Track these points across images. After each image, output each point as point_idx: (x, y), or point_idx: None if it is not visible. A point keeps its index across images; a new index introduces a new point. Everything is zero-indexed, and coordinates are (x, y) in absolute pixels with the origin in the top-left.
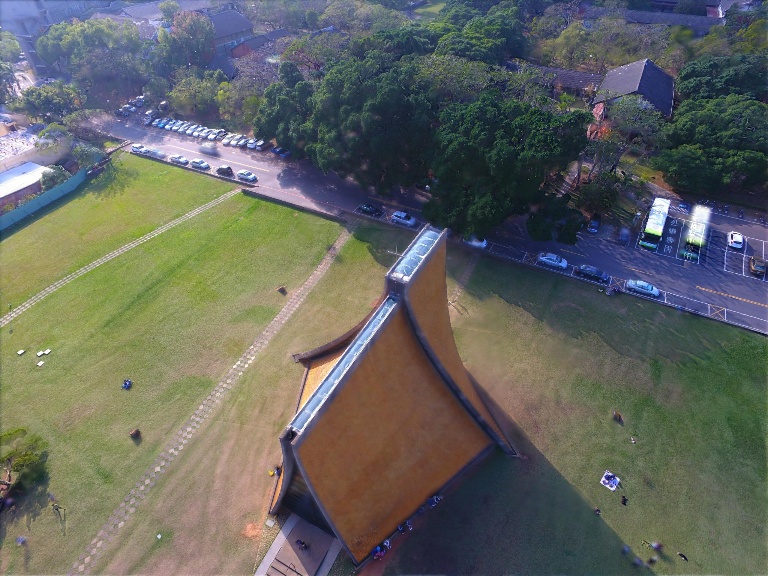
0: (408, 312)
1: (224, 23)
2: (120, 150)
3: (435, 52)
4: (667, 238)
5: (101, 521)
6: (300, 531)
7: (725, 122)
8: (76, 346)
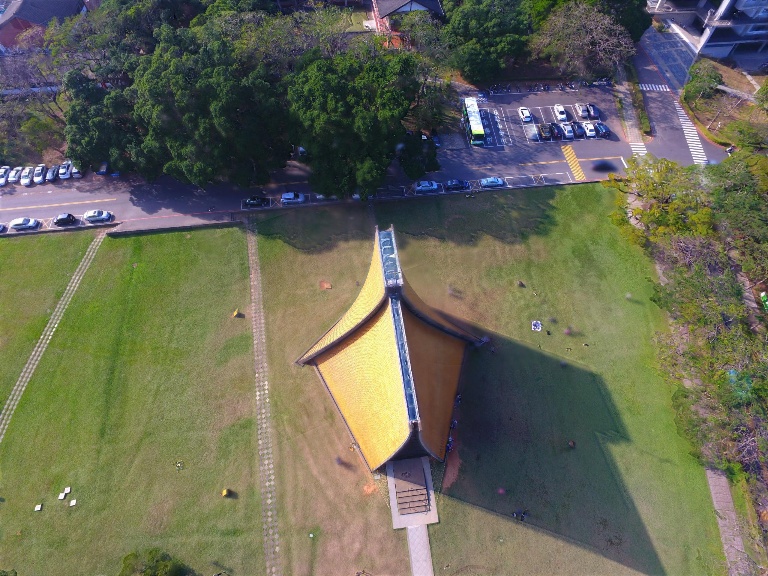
0: (404, 300)
1: None
2: None
3: None
4: (485, 130)
5: (261, 558)
6: (399, 468)
7: (485, 13)
8: (93, 468)
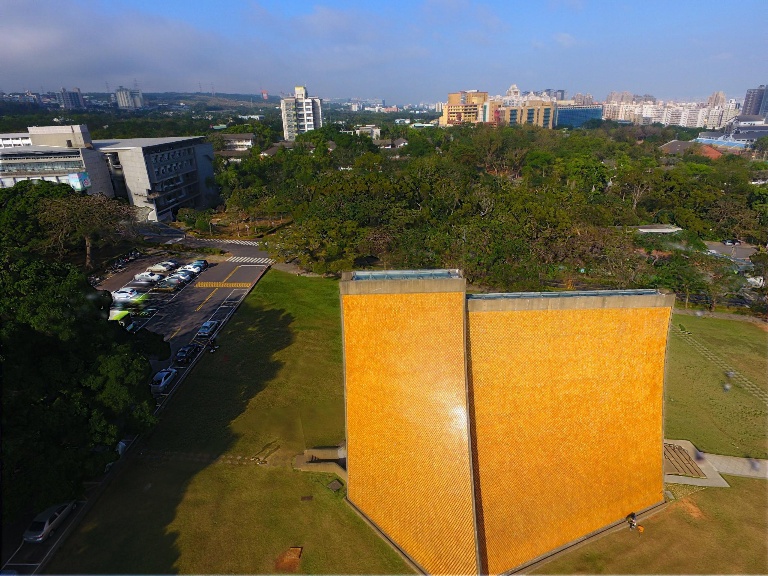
0: None
1: None
2: None
3: None
4: None
5: None
6: None
7: None
8: None
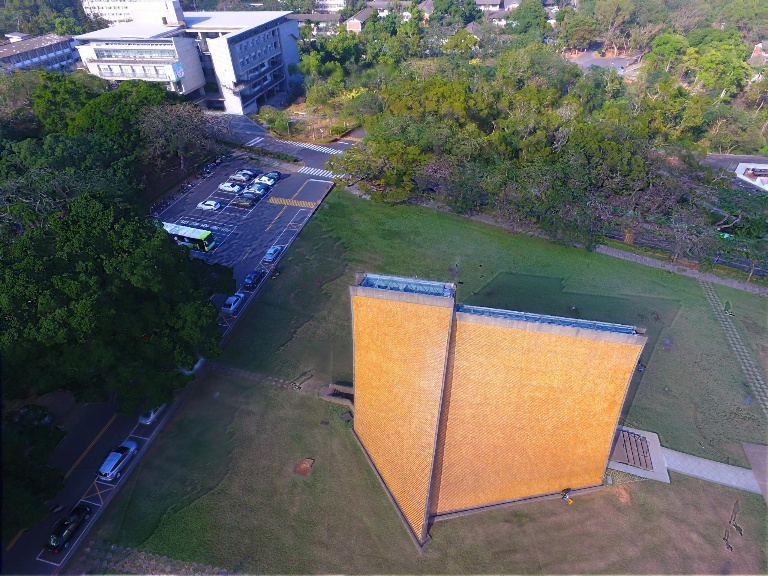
0: None
1: None
2: None
3: None
4: None
5: None
6: None
7: (67, 158)
8: None
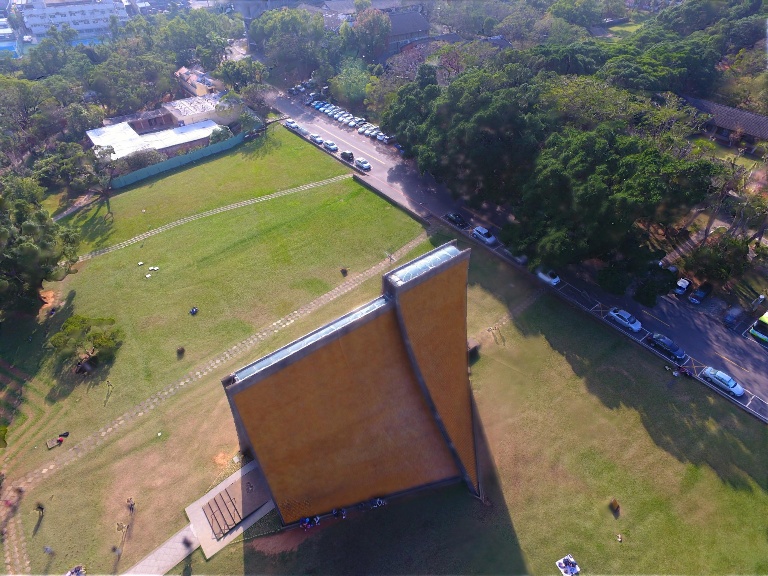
0: (399, 316)
1: (403, 22)
2: (277, 122)
3: (595, 74)
4: None
5: (130, 406)
6: (254, 476)
7: None
8: (176, 270)
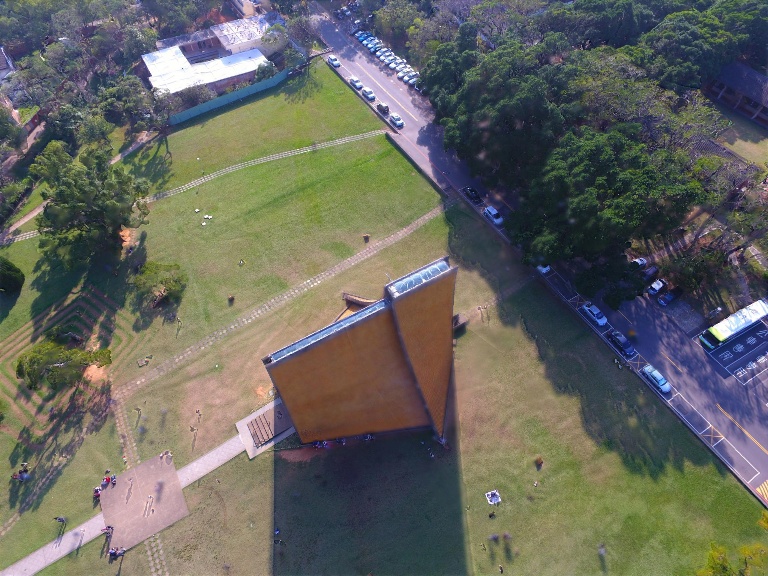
0: None
1: None
2: (320, 57)
3: (647, 34)
4: (737, 345)
5: (195, 340)
6: (283, 407)
7: None
8: (226, 221)
